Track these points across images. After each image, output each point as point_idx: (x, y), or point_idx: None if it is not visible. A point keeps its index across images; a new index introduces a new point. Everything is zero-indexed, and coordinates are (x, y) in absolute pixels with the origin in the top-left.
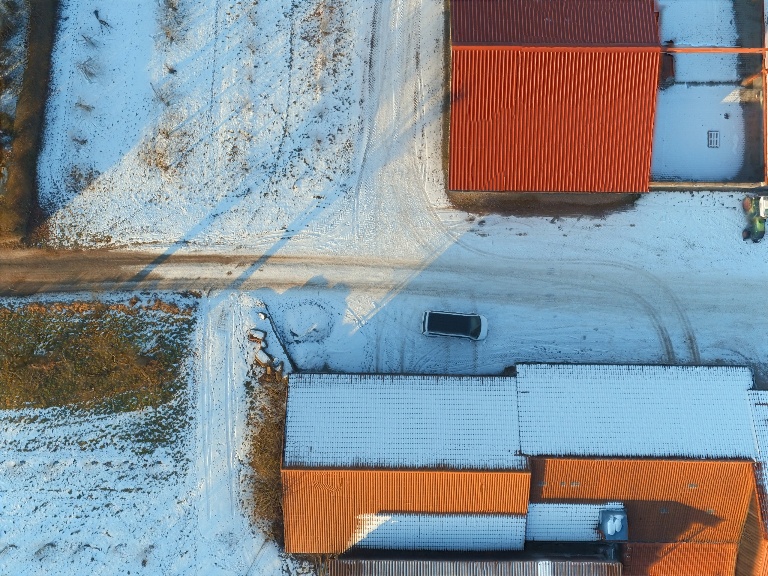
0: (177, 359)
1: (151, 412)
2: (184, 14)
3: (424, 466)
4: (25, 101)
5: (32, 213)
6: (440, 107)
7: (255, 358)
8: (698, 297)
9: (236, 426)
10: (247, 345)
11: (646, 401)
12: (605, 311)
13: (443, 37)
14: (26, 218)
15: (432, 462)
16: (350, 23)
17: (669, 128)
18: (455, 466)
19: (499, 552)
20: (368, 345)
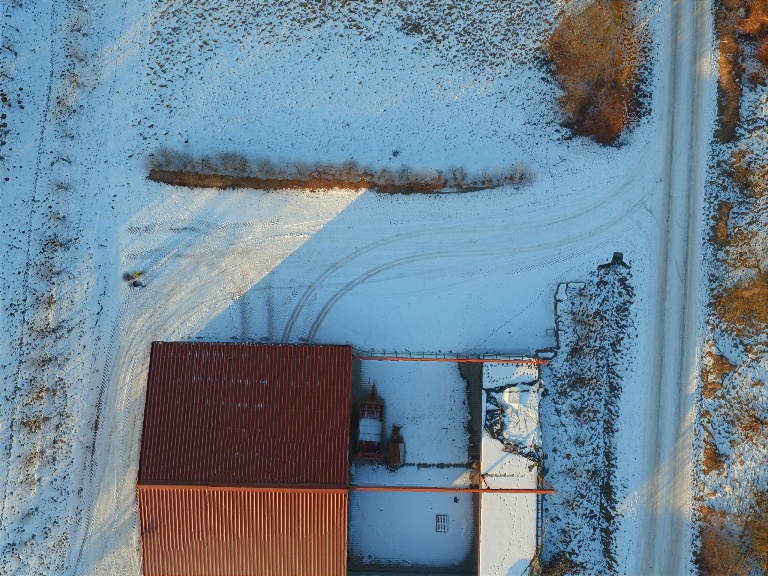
0: None
1: None
2: None
3: None
4: None
5: None
6: None
7: None
8: None
9: None
10: None
11: None
12: None
13: None
14: None
15: None
16: (73, 406)
17: (398, 511)
18: None
19: None
20: None
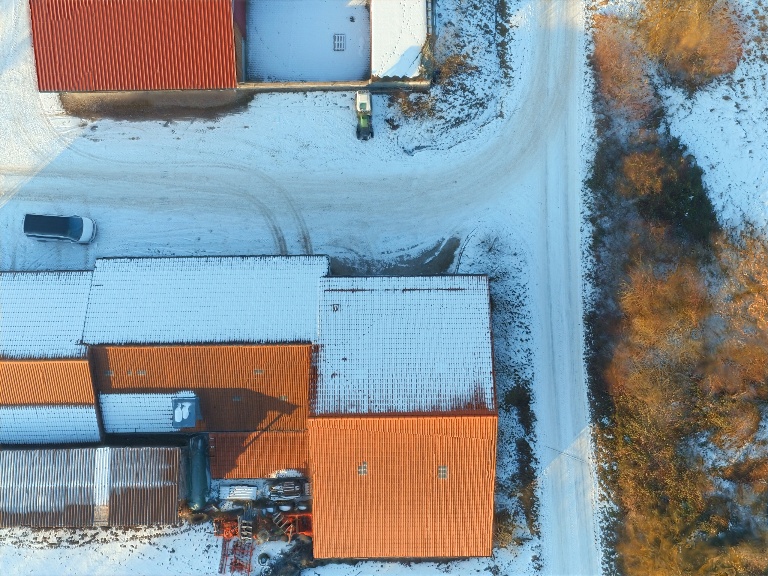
0: None
1: None
2: None
3: None
4: None
5: None
6: None
7: None
8: (313, 196)
9: None
10: None
11: (217, 290)
12: (220, 213)
13: None
14: None
15: None
16: None
17: (295, 33)
18: (14, 356)
19: (76, 444)
20: None
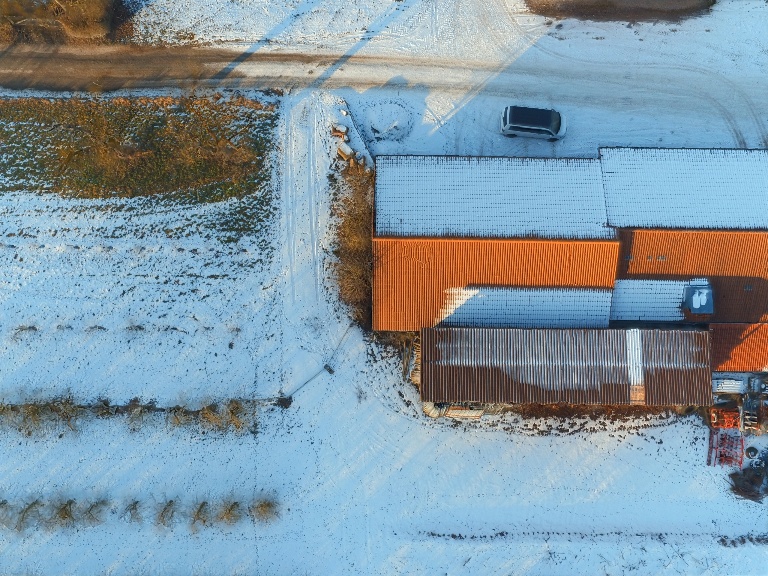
0: (260, 152)
1: (235, 203)
2: None
3: (513, 236)
4: None
5: (116, 11)
6: None
7: (337, 152)
8: None
9: (320, 216)
10: (329, 140)
11: (729, 181)
12: (680, 114)
13: None
14: (111, 14)
15: (521, 232)
16: None
17: None
18: (544, 236)
19: None
20: (447, 145)
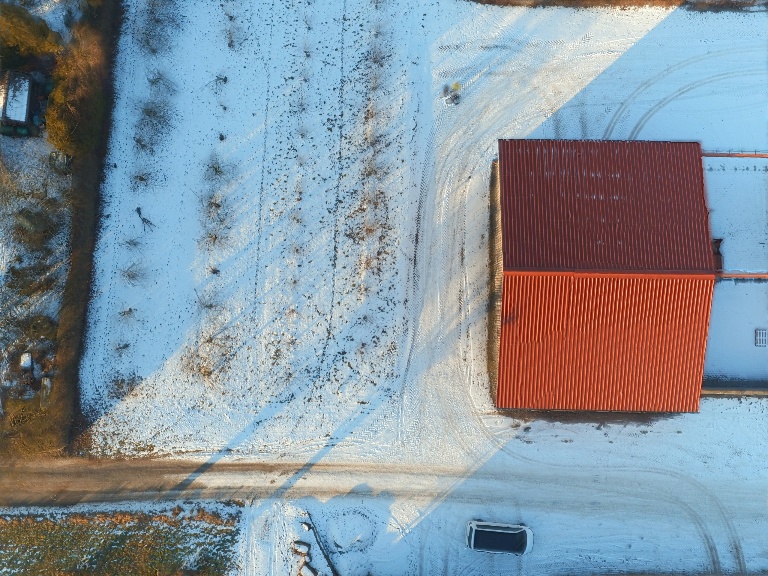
0: (220, 573)
1: None
2: (227, 211)
3: None
4: (68, 310)
5: (74, 421)
6: (485, 306)
7: (299, 572)
8: (745, 505)
9: None
10: (291, 558)
11: None
12: (651, 519)
13: (489, 232)
14: (69, 427)
15: None
16: (395, 219)
17: (716, 326)
18: None
19: None
20: (412, 554)
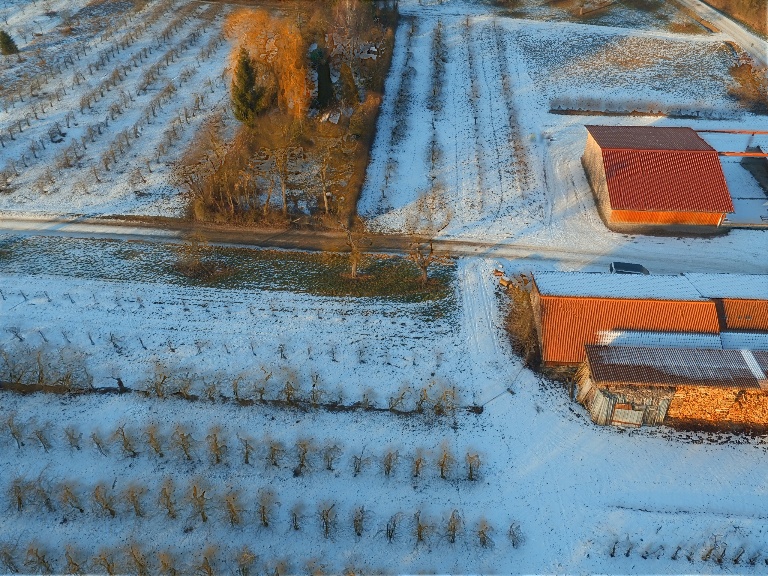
0: (447, 281)
1: (431, 303)
2: (439, 161)
3: None
4: (357, 175)
5: (353, 220)
6: (592, 198)
7: (500, 282)
8: None
9: (492, 311)
10: (493, 277)
11: None
12: None
13: (586, 177)
14: (351, 219)
15: None
16: (532, 169)
17: (735, 214)
18: (660, 299)
19: None
20: None
